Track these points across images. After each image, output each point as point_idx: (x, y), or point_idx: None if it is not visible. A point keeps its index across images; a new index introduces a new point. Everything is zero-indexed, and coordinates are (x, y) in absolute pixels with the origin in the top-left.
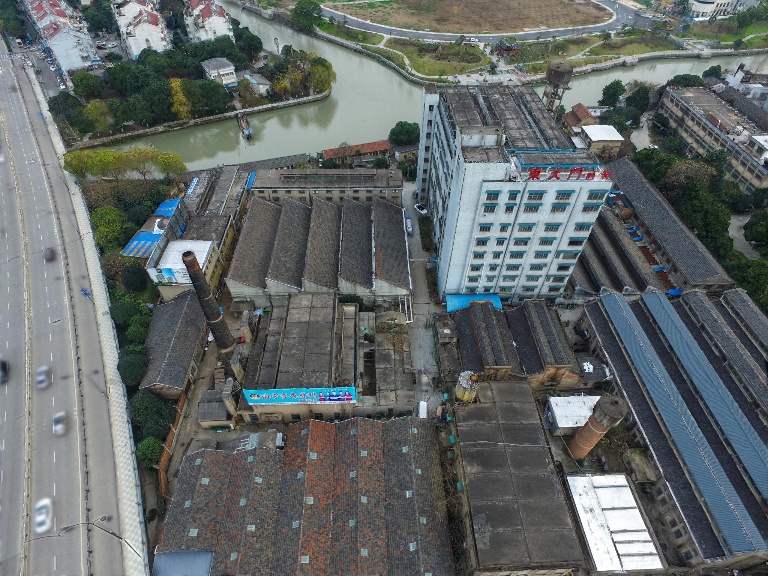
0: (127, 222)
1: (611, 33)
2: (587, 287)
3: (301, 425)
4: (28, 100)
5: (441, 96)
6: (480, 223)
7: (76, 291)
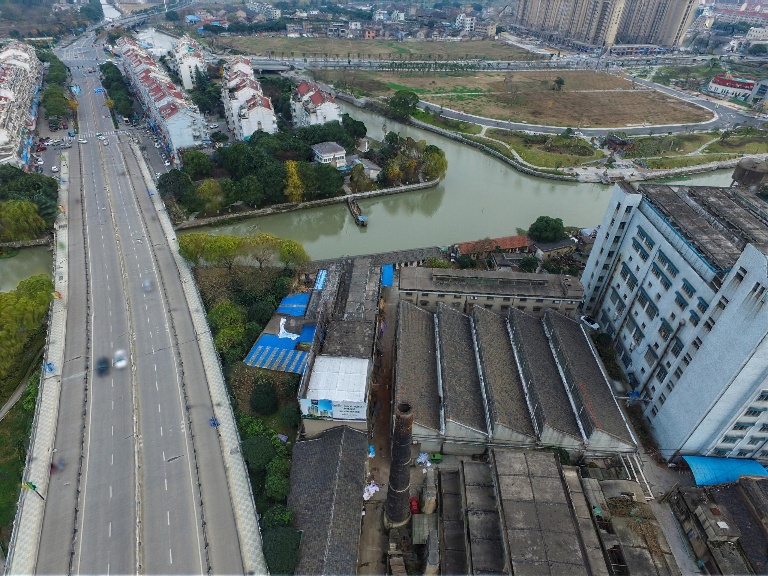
0: (248, 321)
1: (722, 131)
2: None
3: None
4: (134, 175)
5: None
6: None
7: (195, 413)
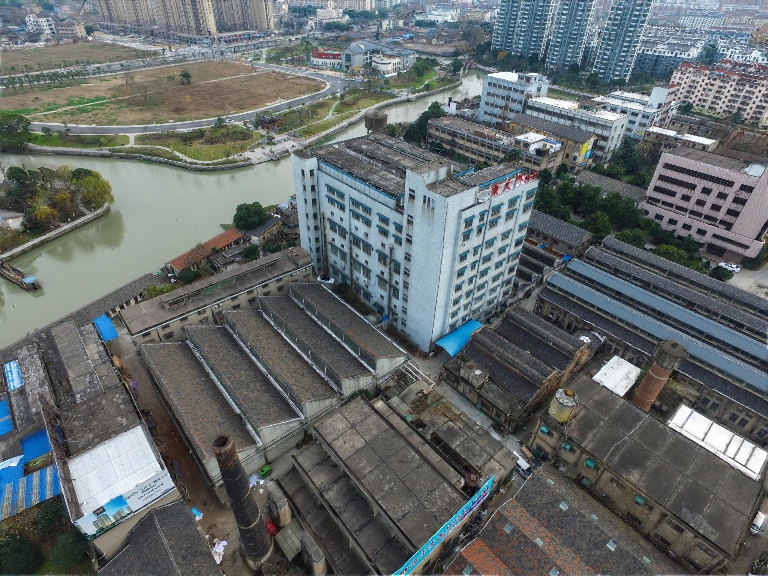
0: None
1: (338, 95)
2: (522, 280)
3: (455, 567)
4: None
5: None
6: (460, 254)
7: None
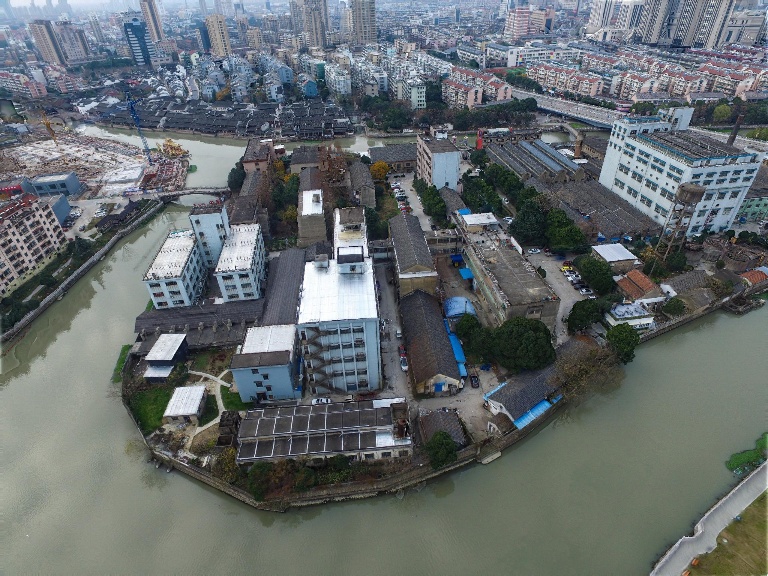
0: None
1: None
2: (588, 183)
3: None
4: None
5: (752, 162)
6: None
7: None
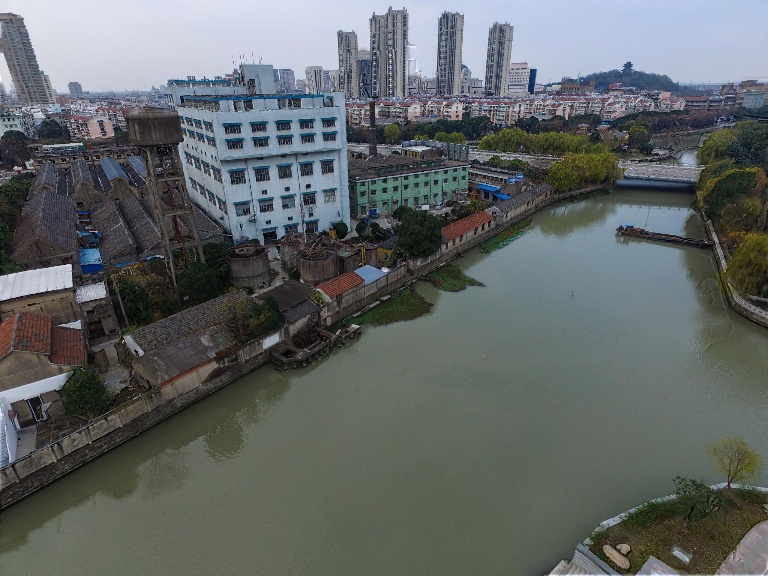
0: None
1: None
2: (166, 195)
3: None
4: None
5: None
6: None
7: None
